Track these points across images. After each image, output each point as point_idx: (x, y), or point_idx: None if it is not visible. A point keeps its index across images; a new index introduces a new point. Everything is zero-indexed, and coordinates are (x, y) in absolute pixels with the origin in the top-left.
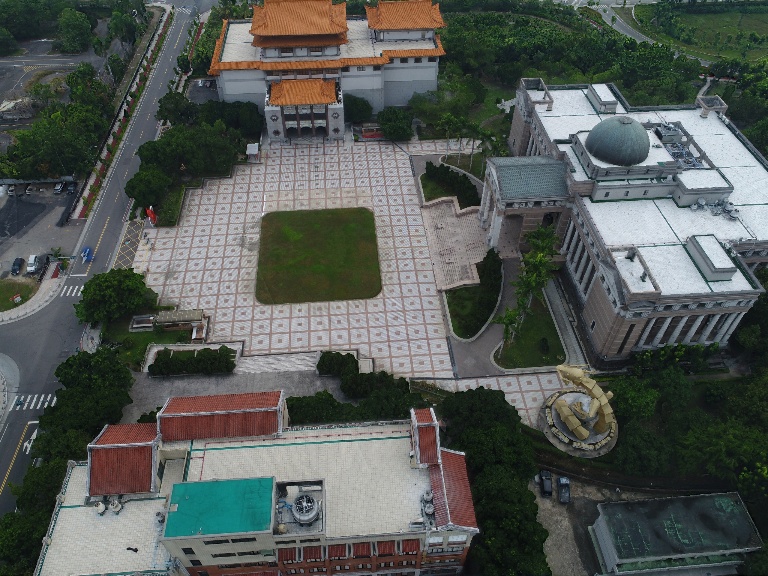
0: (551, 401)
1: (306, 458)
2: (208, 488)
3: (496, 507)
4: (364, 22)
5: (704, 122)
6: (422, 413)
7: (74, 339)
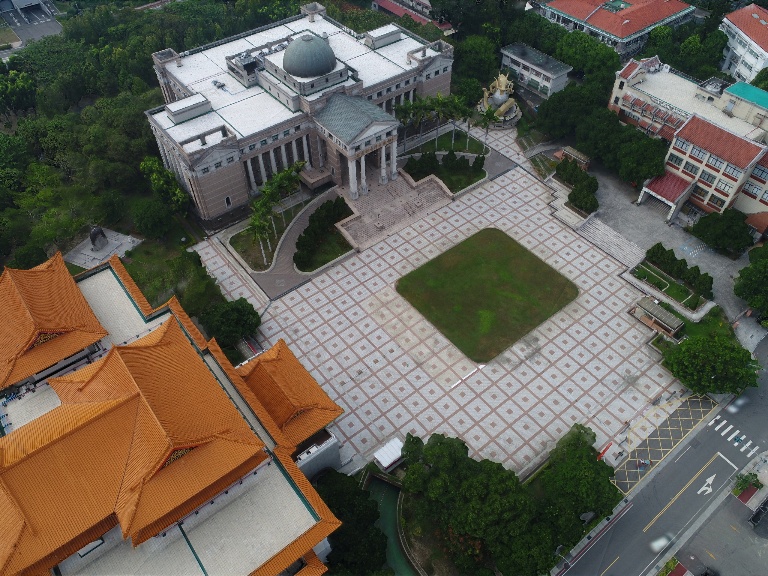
0: (501, 117)
1: (691, 108)
2: (760, 103)
3: (609, 81)
4: (13, 410)
5: (190, 64)
6: (627, 73)
7: (763, 383)
